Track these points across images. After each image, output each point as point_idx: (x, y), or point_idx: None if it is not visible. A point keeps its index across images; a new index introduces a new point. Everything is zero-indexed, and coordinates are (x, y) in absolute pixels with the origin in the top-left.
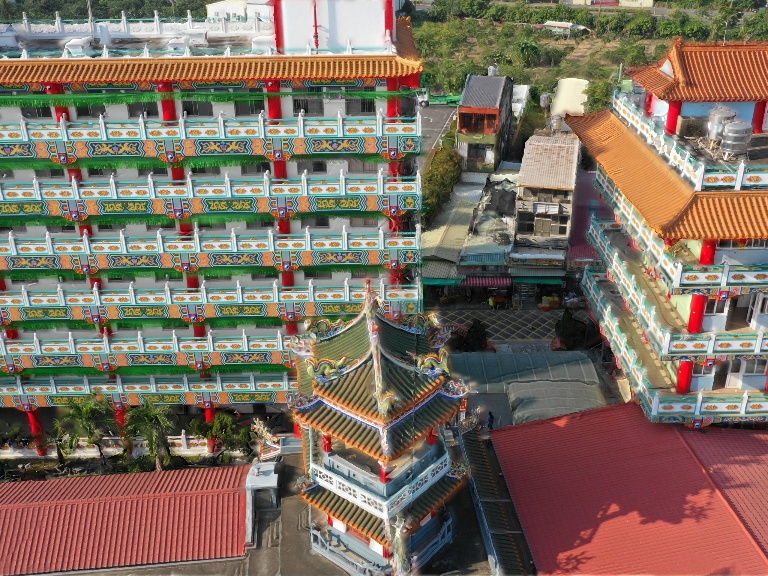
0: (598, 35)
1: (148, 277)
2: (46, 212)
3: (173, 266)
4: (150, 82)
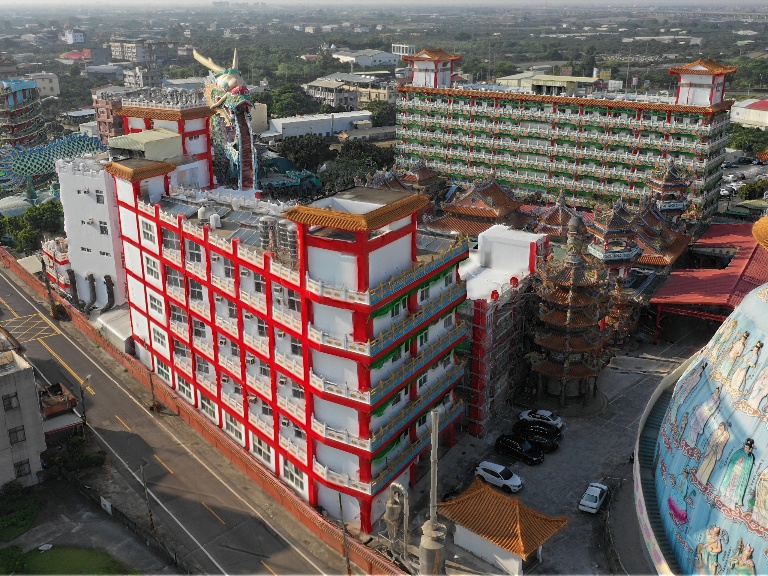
0: None
1: (620, 167)
2: (598, 142)
3: (628, 163)
4: (635, 108)
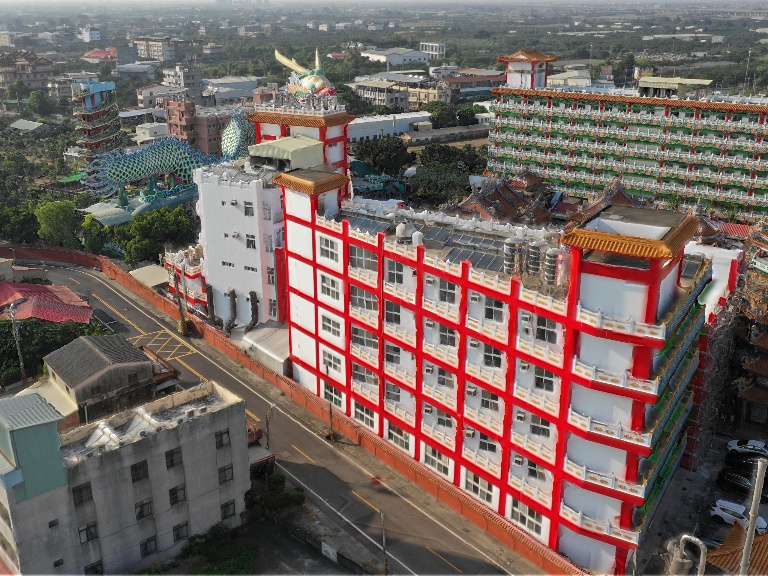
0: None
1: (739, 173)
2: (715, 147)
3: (749, 169)
4: (759, 112)
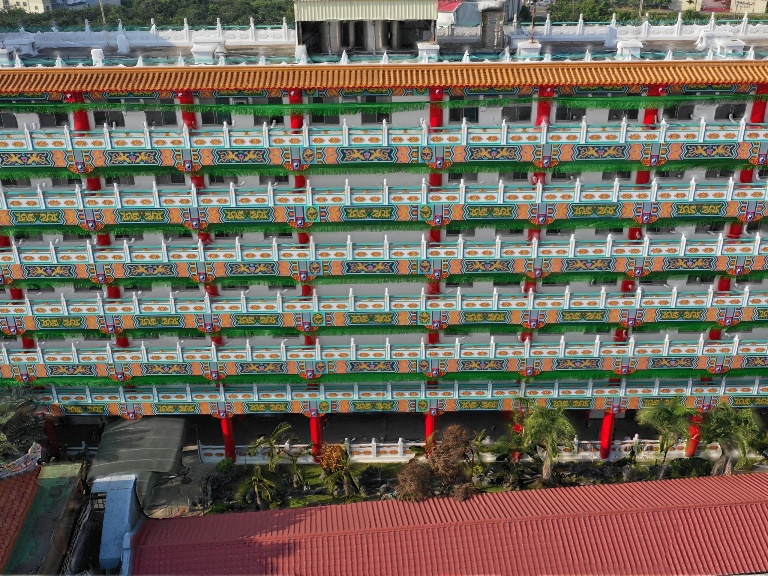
0: None
1: (681, 280)
2: (618, 214)
3: (726, 269)
4: None
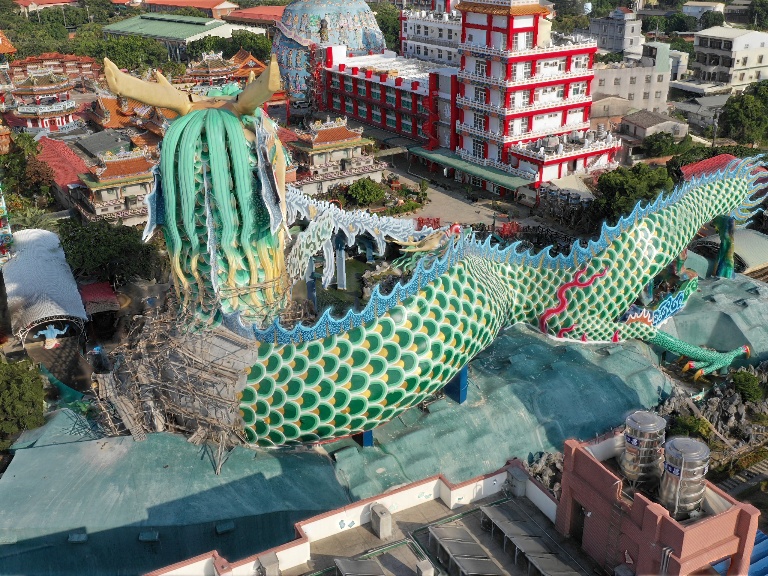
0: None
1: None
2: None
3: None
4: None
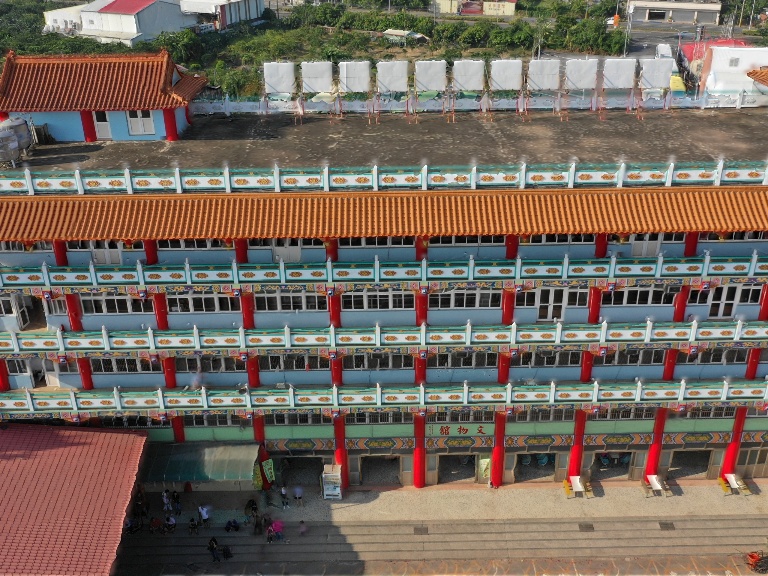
0: (435, 43)
1: None
2: None
3: None
4: None
